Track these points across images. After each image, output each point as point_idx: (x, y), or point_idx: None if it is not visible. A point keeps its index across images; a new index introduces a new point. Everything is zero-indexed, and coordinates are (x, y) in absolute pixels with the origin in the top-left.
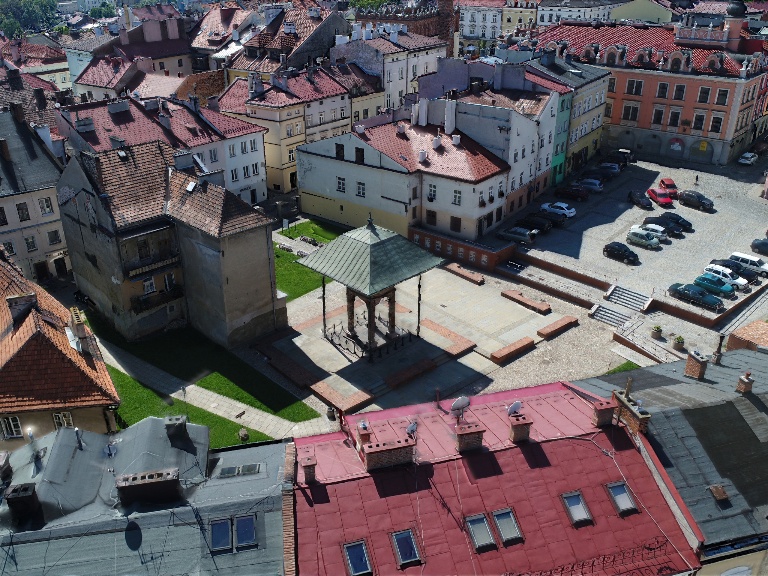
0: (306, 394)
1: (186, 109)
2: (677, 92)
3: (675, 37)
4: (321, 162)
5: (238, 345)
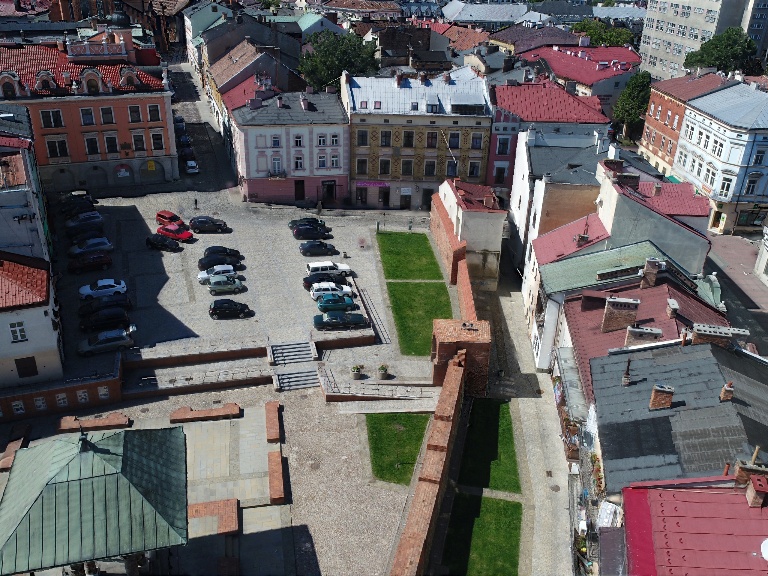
0: None
1: None
2: (104, 116)
3: (68, 55)
4: None
5: None
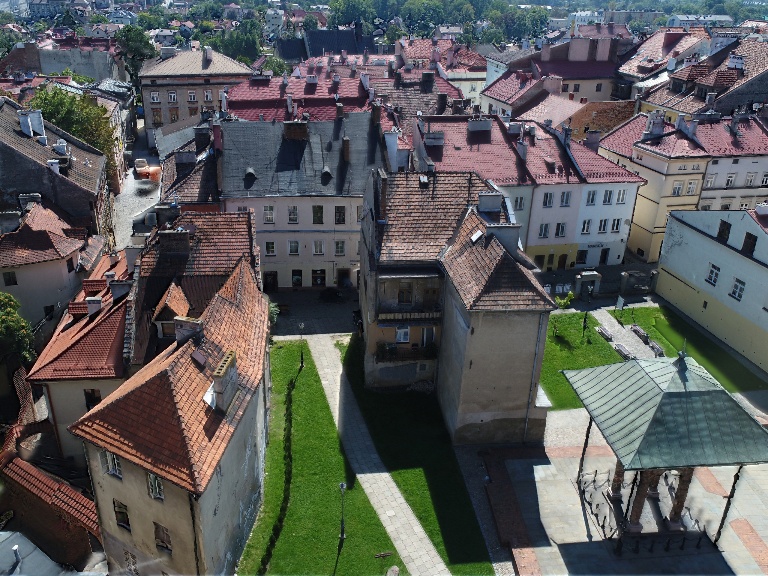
0: (503, 556)
1: (555, 140)
2: None
3: None
4: (695, 238)
5: (467, 444)
